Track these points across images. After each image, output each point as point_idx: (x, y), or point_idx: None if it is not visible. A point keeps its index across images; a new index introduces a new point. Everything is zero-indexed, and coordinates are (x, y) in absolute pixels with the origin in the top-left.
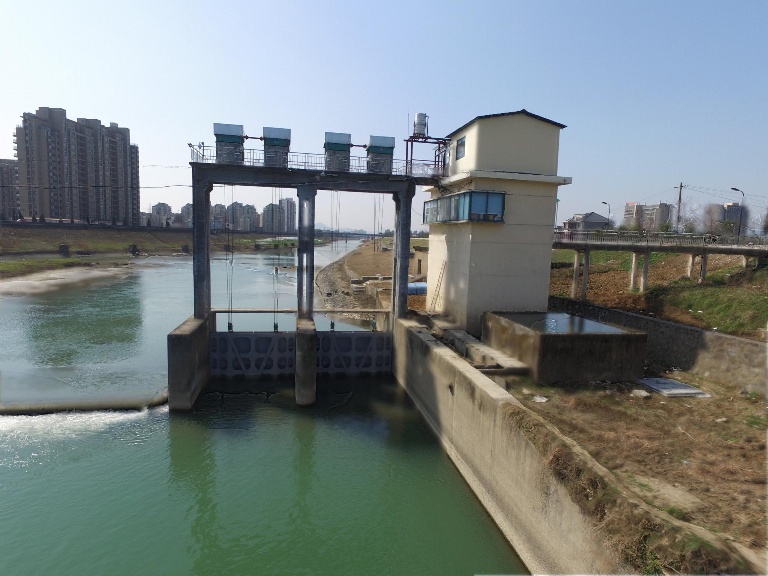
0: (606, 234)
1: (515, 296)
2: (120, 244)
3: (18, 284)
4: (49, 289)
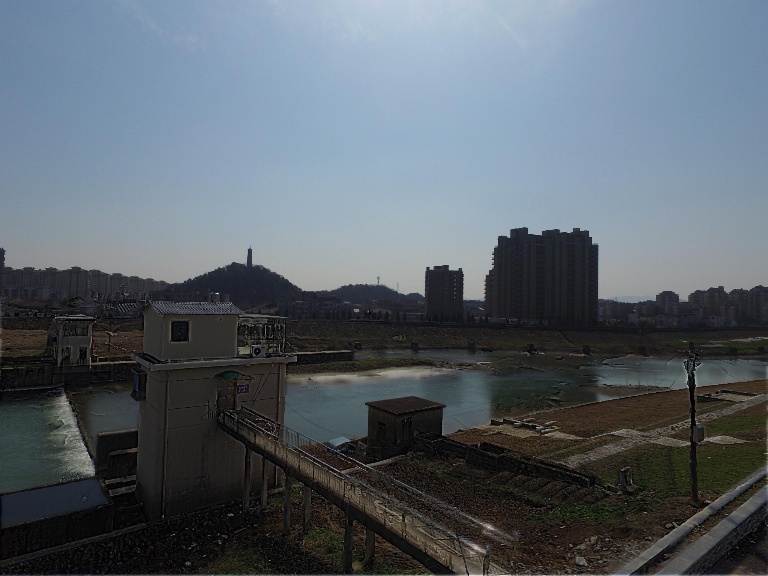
0: (257, 431)
1: (146, 472)
2: (525, 342)
3: (344, 377)
4: (343, 384)
